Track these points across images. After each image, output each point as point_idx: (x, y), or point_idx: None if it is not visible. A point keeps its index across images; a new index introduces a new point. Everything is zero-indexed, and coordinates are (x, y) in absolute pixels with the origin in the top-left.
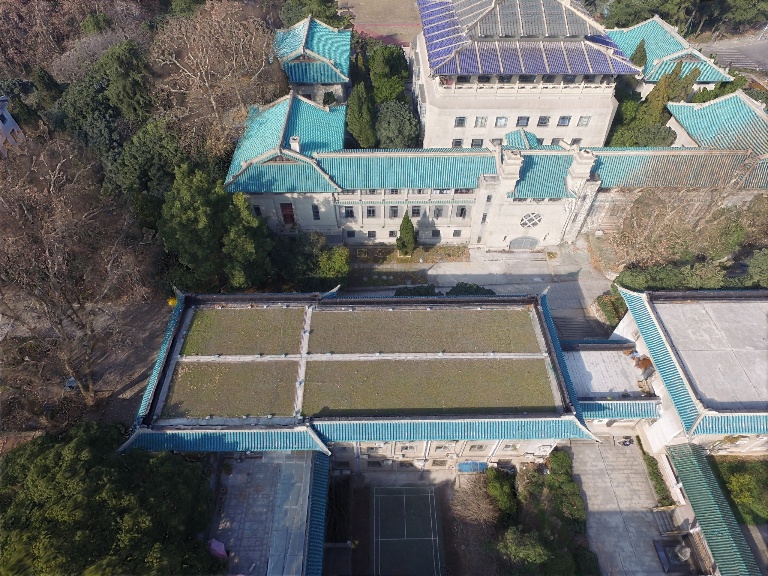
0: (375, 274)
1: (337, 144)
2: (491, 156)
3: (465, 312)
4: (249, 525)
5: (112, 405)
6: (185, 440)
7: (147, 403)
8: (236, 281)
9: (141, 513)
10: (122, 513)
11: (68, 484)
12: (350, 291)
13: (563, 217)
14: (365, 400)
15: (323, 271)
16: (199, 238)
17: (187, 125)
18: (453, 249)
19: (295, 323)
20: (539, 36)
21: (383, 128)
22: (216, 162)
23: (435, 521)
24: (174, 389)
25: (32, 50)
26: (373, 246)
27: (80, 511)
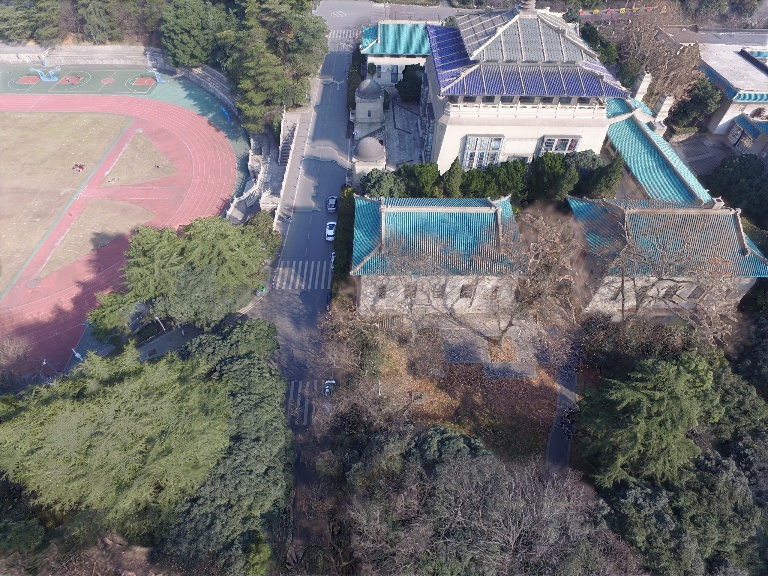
0: None
1: None
2: None
3: None
4: None
5: None
6: None
7: None
8: None
9: None
10: None
11: None
12: None
13: None
14: None
15: None
16: None
17: None
18: None
19: None
20: None
21: None
22: None
23: None
24: None
25: None
26: None
27: None
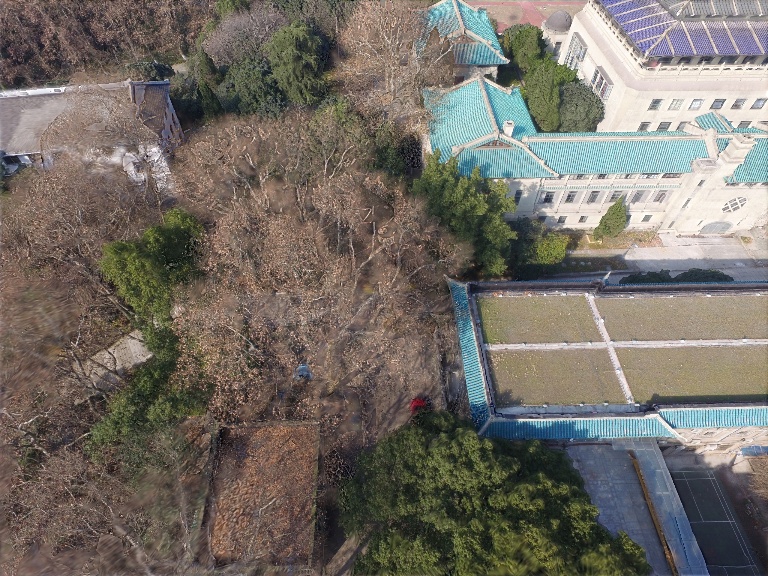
0: (572, 260)
1: (531, 128)
2: (700, 140)
3: (746, 298)
4: (602, 511)
5: (344, 393)
6: (536, 428)
7: (484, 392)
8: (496, 269)
9: (582, 501)
10: (566, 502)
11: (490, 474)
12: (550, 277)
13: (767, 201)
14: (691, 387)
15: (541, 257)
16: (469, 225)
17: (377, 109)
18: (642, 234)
19: (583, 310)
20: (747, 15)
21: (570, 111)
22: (394, 147)
23: (726, 504)
24: (496, 378)
25: (157, 31)
26: (560, 232)
27: (540, 500)
